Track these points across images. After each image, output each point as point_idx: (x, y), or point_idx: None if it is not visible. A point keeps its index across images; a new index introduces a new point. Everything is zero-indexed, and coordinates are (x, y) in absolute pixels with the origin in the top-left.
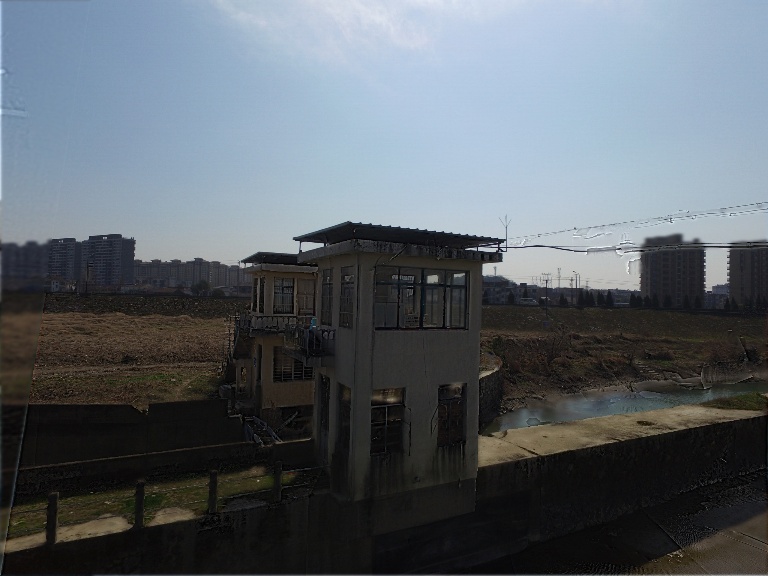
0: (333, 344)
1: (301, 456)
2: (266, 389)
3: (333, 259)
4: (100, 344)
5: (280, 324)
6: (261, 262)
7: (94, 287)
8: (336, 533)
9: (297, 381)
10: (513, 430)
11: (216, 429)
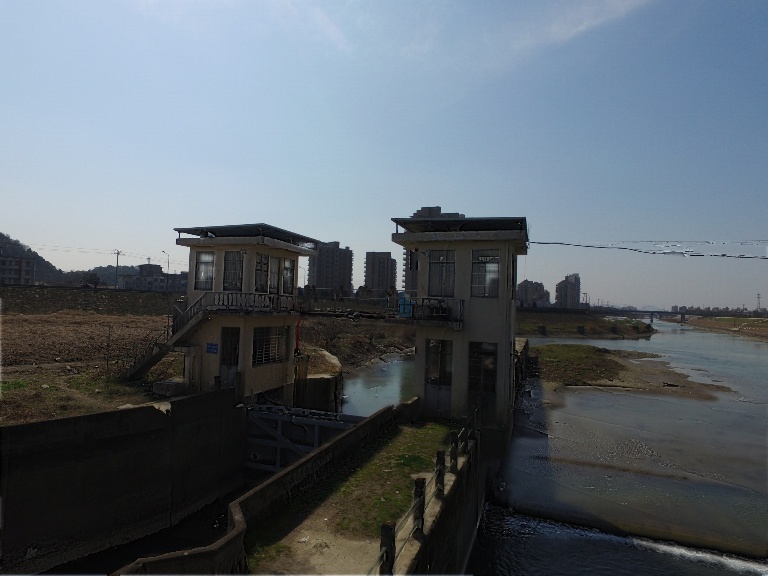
0: (463, 311)
1: (416, 412)
2: (247, 375)
3: (458, 242)
4: None
5: (258, 304)
6: (236, 234)
7: None
8: (498, 453)
9: (267, 364)
10: None
11: (228, 423)
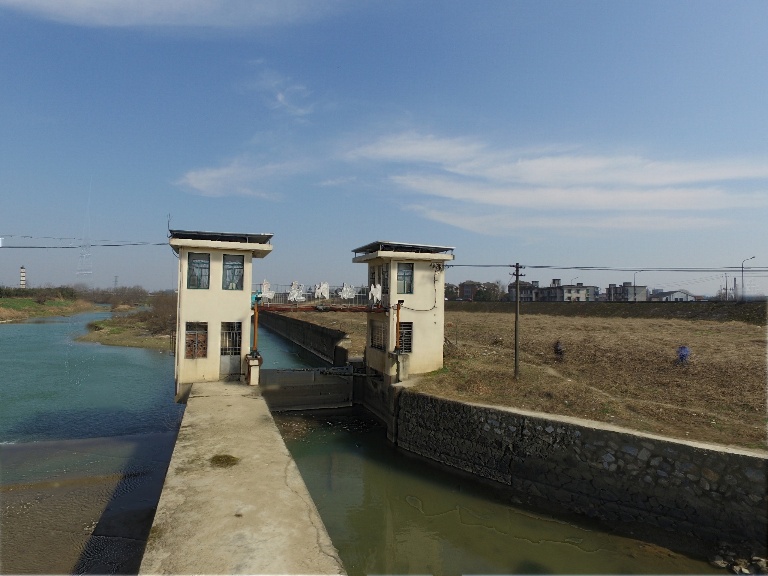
0: None
1: None
2: None
3: None
4: (545, 335)
5: (371, 302)
6: None
7: (750, 294)
8: None
9: (376, 349)
10: (260, 401)
11: None
